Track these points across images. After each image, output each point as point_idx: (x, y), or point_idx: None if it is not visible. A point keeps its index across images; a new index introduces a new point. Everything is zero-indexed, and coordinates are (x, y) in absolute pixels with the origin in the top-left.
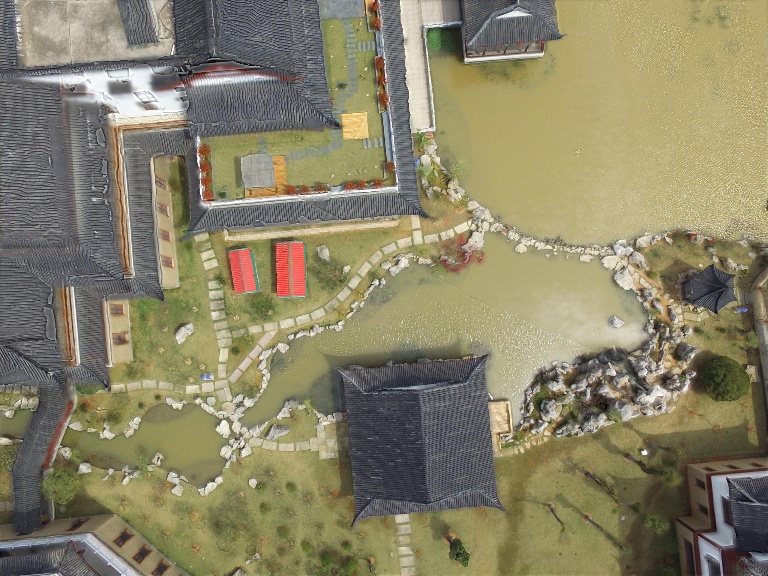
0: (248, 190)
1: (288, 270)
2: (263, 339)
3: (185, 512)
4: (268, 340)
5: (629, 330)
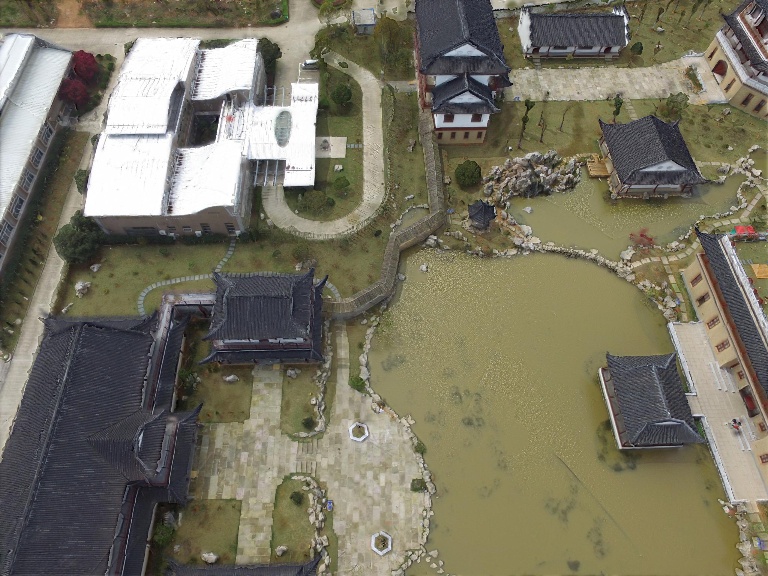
0: None
1: None
2: (748, 214)
3: (764, 139)
4: (745, 213)
5: (519, 207)
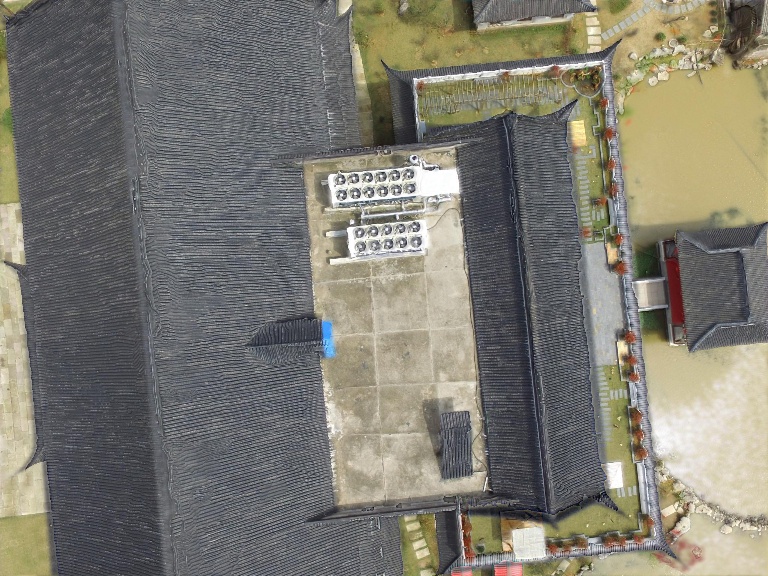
0: (505, 543)
1: (507, 568)
2: None
3: None
4: None
5: None
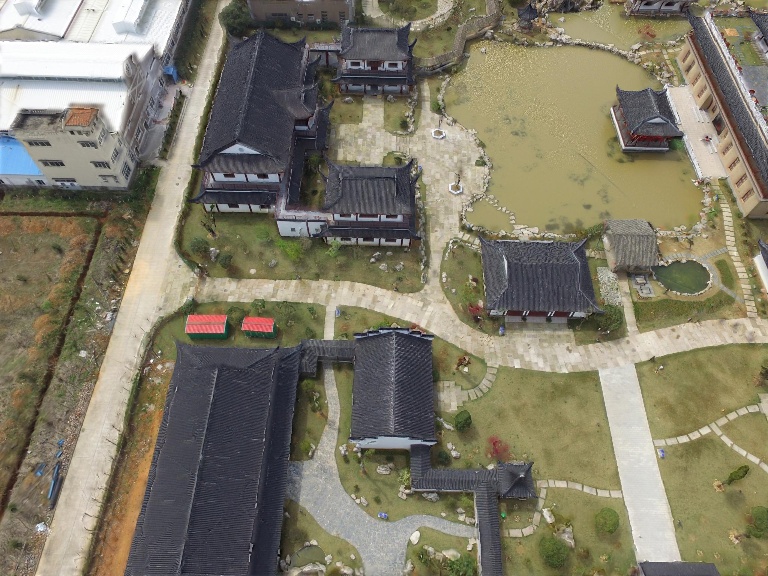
0: None
1: None
2: None
3: None
4: None
5: (555, 18)
